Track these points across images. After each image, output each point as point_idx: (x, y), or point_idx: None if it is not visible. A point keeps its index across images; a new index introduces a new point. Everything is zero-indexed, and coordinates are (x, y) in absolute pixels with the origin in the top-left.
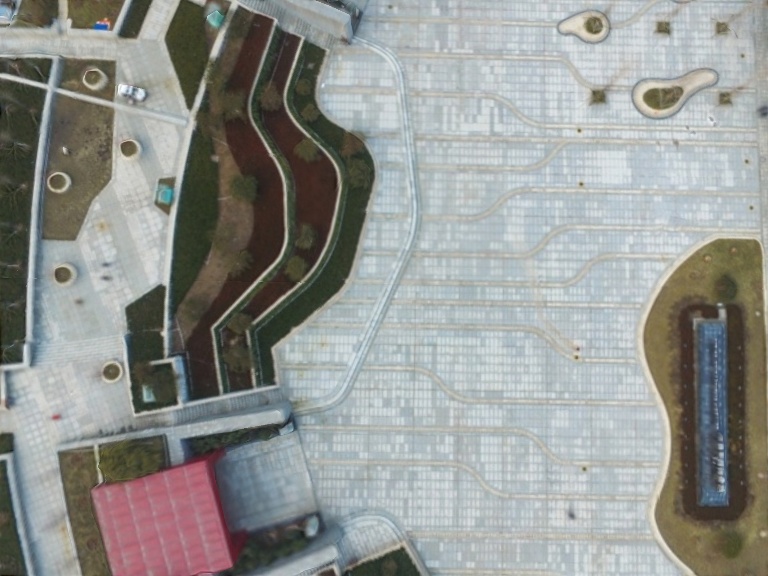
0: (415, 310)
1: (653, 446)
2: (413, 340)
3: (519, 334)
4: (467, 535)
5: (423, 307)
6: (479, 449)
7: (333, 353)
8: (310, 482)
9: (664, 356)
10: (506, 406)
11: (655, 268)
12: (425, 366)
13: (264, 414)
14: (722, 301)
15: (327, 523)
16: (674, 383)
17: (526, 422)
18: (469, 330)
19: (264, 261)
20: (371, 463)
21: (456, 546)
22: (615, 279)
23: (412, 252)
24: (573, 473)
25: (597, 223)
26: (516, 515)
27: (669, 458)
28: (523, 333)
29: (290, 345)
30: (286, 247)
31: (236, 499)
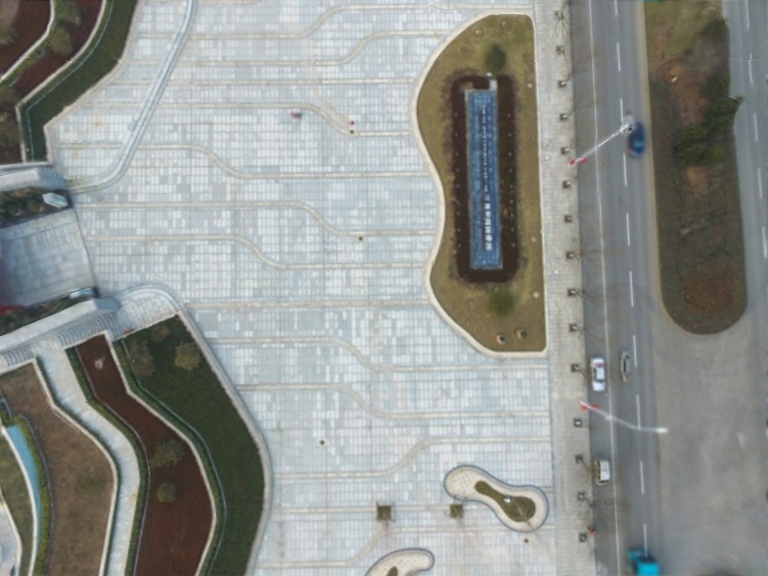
0: (191, 90)
1: (428, 214)
2: (189, 119)
3: (295, 111)
4: (245, 305)
5: (199, 87)
6: (256, 222)
7: (108, 132)
8: (87, 258)
9: (437, 127)
10: (283, 180)
11: (428, 44)
12: (201, 144)
13: (20, 173)
14: (491, 71)
15: (102, 295)
16: (447, 152)
17: (303, 195)
18: (245, 108)
19: (30, 37)
20: (148, 239)
21: (234, 316)
22: (389, 56)
23: (188, 35)
24: (350, 243)
25: (371, 3)
26: (293, 285)
27: (443, 225)
28: (299, 110)
29: (64, 125)
30: (52, 23)
31: (12, 276)
